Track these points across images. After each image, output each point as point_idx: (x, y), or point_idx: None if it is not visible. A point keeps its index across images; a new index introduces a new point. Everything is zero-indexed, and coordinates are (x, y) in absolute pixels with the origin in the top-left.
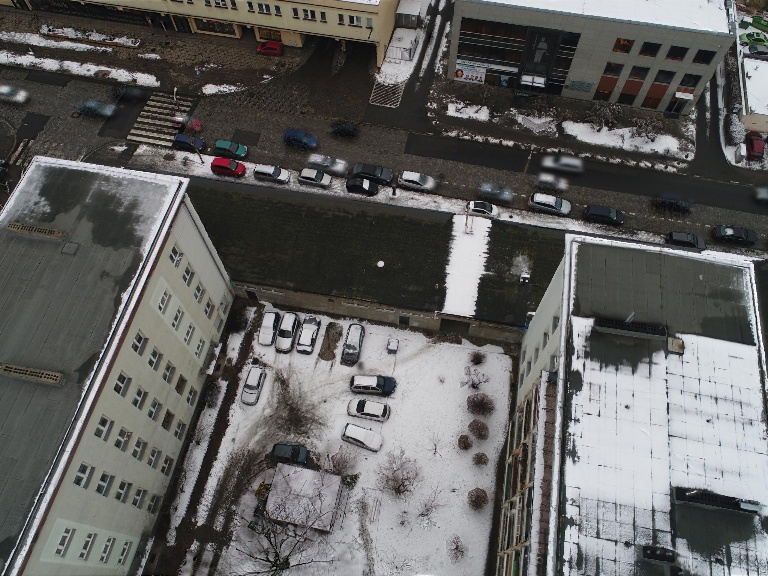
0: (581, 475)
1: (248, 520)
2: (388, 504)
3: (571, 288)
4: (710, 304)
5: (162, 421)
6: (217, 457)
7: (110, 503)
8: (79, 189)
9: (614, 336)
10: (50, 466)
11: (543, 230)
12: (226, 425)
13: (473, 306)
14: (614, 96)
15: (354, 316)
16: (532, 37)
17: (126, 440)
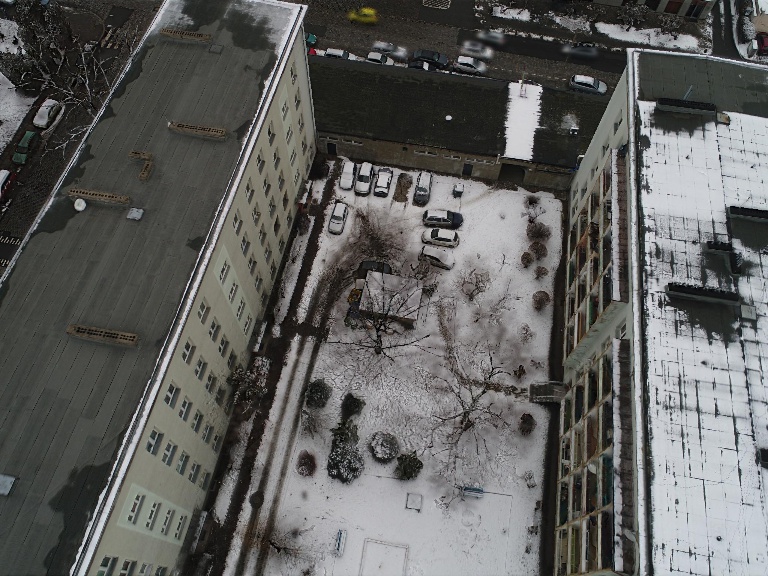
0: (654, 200)
1: (342, 319)
2: (462, 308)
3: (635, 82)
4: (748, 94)
5: (274, 223)
6: (311, 273)
7: (246, 266)
8: (216, 9)
9: (673, 113)
10: (224, 193)
11: (587, 95)
12: (316, 249)
13: (530, 152)
14: (641, 1)
15: (422, 168)
16: None
17: (257, 218)
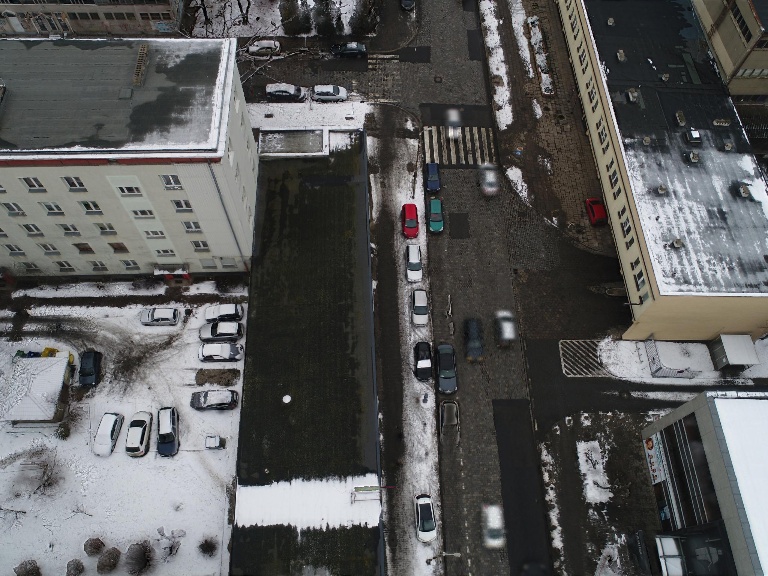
0: None
1: (30, 350)
2: None
3: None
4: None
5: (75, 243)
6: (90, 307)
7: None
8: (195, 78)
9: None
10: None
11: None
12: (121, 305)
13: (250, 522)
14: None
15: None
16: (715, 532)
17: (19, 213)
